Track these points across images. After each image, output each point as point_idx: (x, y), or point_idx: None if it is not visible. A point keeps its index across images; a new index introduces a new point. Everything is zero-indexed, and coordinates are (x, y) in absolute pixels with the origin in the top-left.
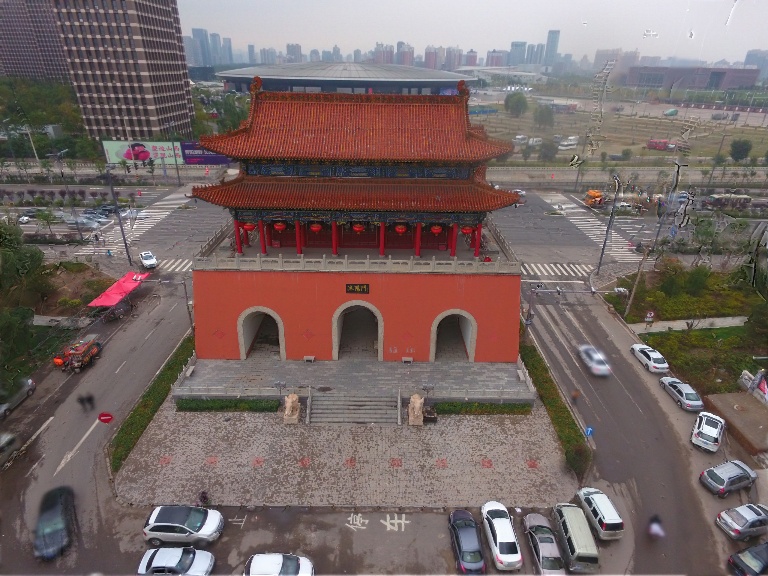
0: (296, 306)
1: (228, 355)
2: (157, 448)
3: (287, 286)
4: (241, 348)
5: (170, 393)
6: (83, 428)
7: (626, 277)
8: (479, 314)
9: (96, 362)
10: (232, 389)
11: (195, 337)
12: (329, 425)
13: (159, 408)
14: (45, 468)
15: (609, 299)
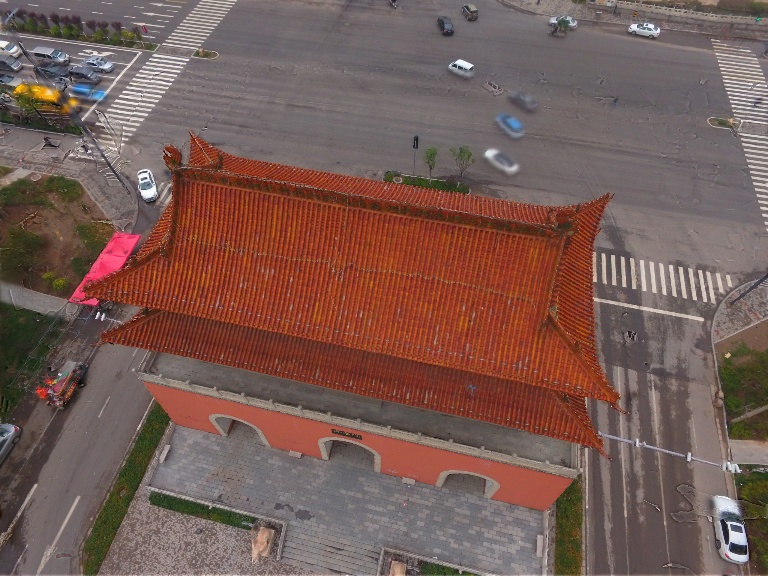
0: (273, 425)
1: (208, 430)
2: (127, 563)
3: (258, 413)
4: (220, 430)
5: (148, 469)
6: (63, 510)
7: (767, 359)
8: (505, 481)
9: (80, 394)
10: (203, 501)
11: (168, 413)
12: (301, 567)
13: (135, 494)
14: (27, 567)
15: (724, 378)
